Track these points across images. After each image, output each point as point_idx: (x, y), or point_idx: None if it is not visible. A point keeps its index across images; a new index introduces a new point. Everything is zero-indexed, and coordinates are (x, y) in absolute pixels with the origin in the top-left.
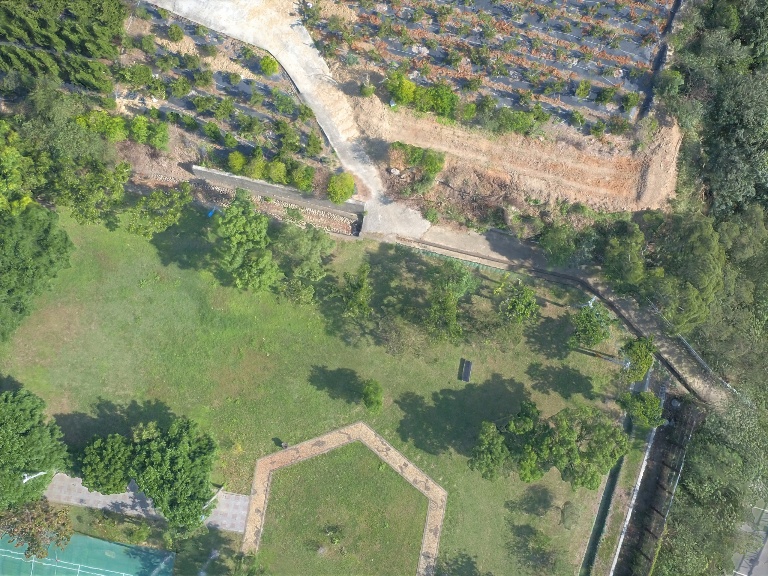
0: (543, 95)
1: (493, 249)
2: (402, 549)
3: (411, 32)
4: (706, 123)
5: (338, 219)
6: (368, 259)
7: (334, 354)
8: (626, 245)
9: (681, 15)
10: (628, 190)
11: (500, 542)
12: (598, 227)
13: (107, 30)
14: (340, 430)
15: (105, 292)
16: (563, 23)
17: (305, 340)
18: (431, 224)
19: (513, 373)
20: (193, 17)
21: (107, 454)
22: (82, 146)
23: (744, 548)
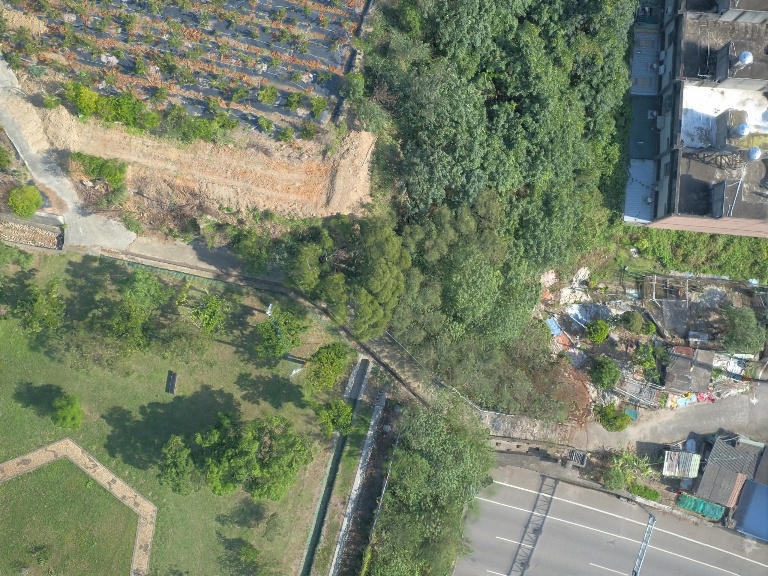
0: (233, 102)
1: (201, 259)
2: (112, 567)
3: (101, 42)
4: (400, 126)
5: (43, 233)
6: (72, 272)
7: (38, 370)
8: None
9: None
10: (318, 195)
11: (212, 556)
12: (296, 234)
13: None
14: (46, 448)
15: None
16: (252, 29)
17: (8, 357)
18: (137, 235)
19: (222, 384)
20: None
21: None
22: None
23: (453, 554)
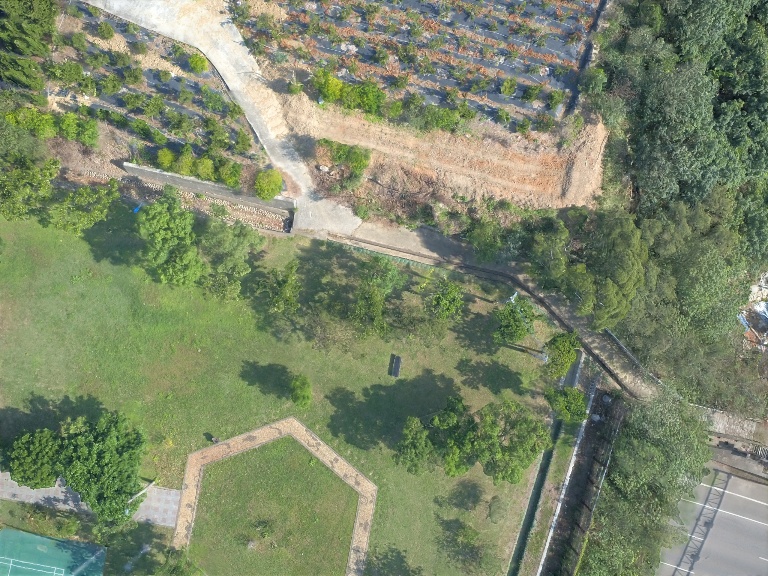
0: (470, 93)
1: (424, 246)
2: (332, 543)
3: (340, 30)
4: (632, 121)
5: (270, 216)
6: (299, 255)
7: (265, 350)
8: (549, 241)
9: (606, 14)
10: (553, 187)
11: (430, 536)
12: (525, 224)
13: (37, 28)
14: (271, 425)
15: (38, 288)
16: (490, 21)
17: (236, 336)
18: (362, 221)
19: (443, 369)
20: (124, 15)
21: (34, 448)
22: (11, 143)
23: (670, 542)
